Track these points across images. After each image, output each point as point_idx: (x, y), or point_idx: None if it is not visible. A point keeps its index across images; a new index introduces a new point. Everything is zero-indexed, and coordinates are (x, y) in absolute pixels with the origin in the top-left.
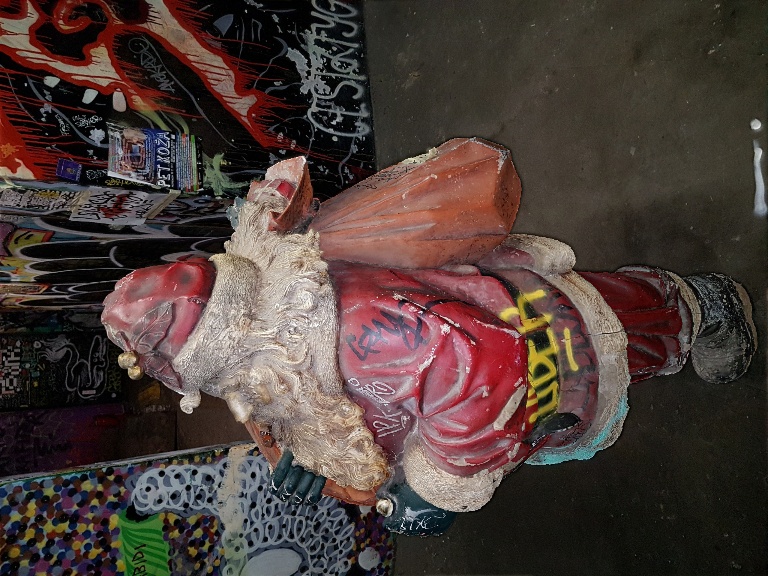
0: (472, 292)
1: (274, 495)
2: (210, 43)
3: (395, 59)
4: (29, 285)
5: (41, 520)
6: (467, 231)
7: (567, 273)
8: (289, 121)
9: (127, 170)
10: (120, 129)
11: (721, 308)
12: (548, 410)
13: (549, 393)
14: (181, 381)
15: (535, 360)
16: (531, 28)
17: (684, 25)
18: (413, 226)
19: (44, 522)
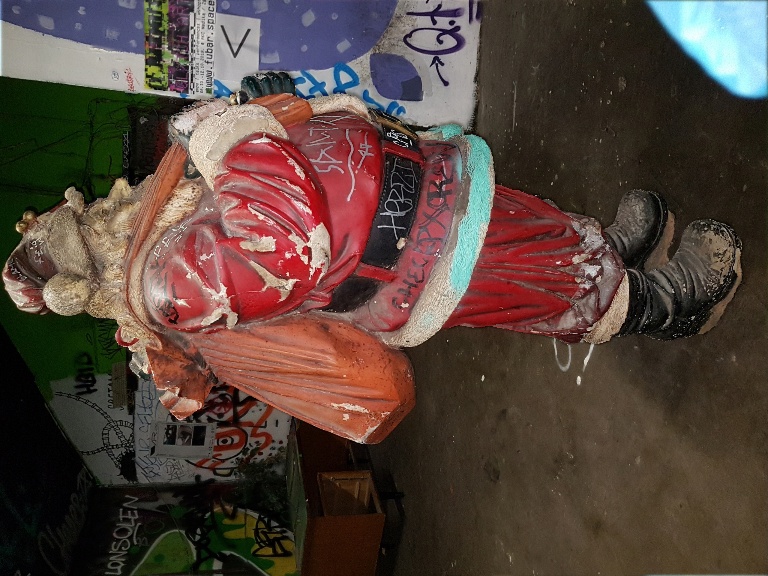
0: None
1: None
2: None
3: None
4: None
5: None
6: None
7: None
8: None
9: None
10: None
11: None
12: None
13: None
14: None
15: None
16: None
17: (571, 495)
18: None
19: None
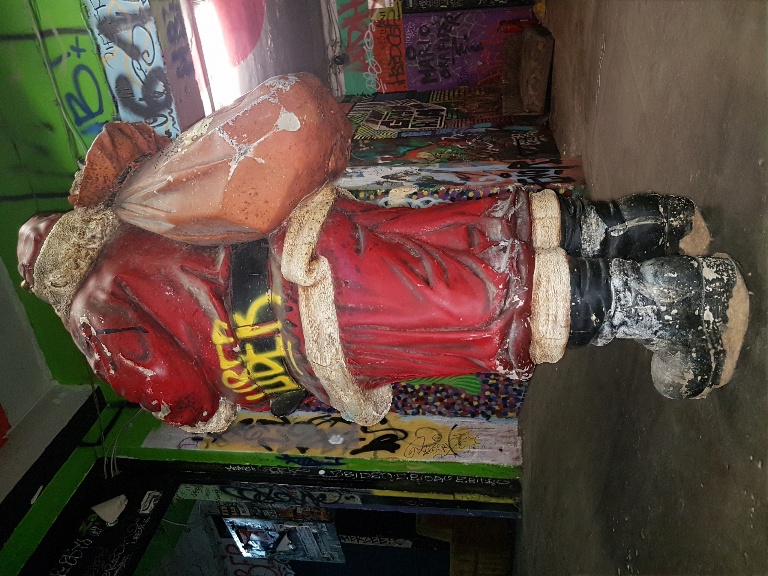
0: (197, 295)
1: None
2: None
3: None
4: None
5: None
6: (215, 229)
7: (311, 286)
8: None
9: None
10: None
11: (651, 327)
12: (287, 389)
13: (276, 382)
14: None
15: (253, 359)
16: None
17: None
18: (163, 222)
19: None
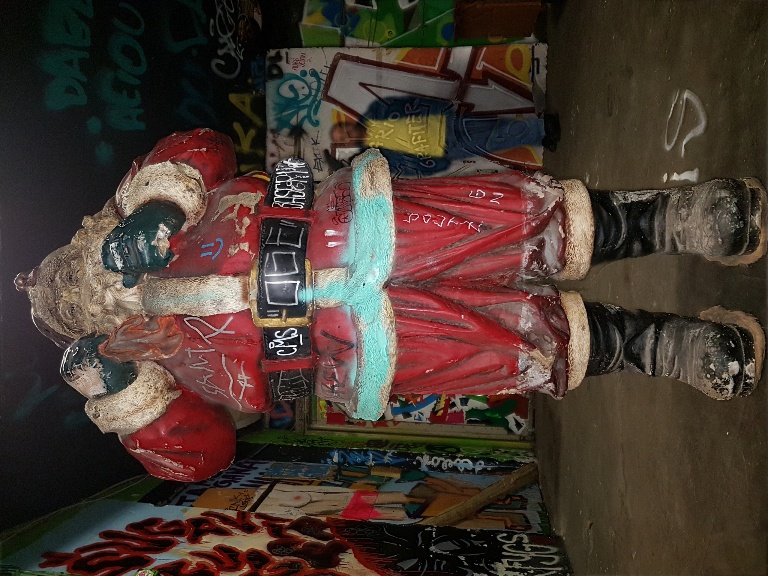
0: None
1: None
2: (390, 574)
3: None
4: None
5: None
6: None
7: None
8: None
9: None
10: None
11: None
12: None
13: None
14: (40, 271)
15: None
16: None
17: None
18: None
19: None
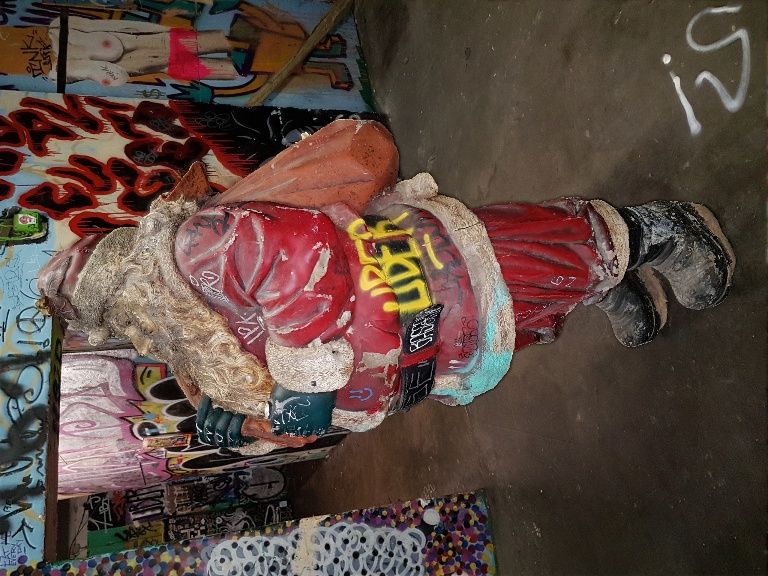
0: None
1: (352, 568)
2: None
3: (417, 155)
4: (175, 436)
5: None
6: (332, 182)
7: (434, 197)
8: None
9: None
10: None
11: (668, 224)
12: (419, 308)
13: (412, 290)
14: (79, 313)
15: (390, 261)
16: (494, 78)
17: (591, 13)
18: (279, 184)
19: None
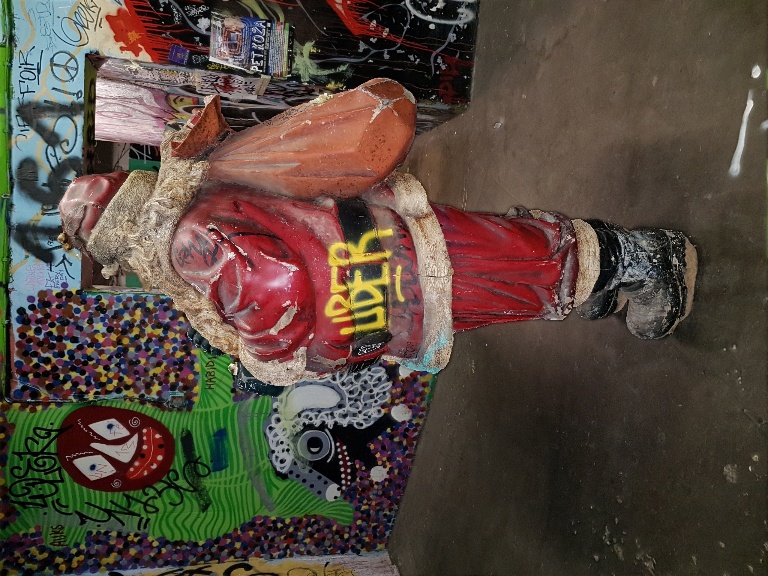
0: (314, 225)
1: None
2: None
3: None
4: None
5: (144, 323)
6: (335, 171)
7: (423, 218)
8: (385, 8)
9: (225, 56)
10: (222, 18)
11: (646, 267)
12: (374, 328)
13: (371, 315)
14: (93, 258)
15: (359, 287)
16: None
17: None
18: (283, 163)
19: (146, 325)
